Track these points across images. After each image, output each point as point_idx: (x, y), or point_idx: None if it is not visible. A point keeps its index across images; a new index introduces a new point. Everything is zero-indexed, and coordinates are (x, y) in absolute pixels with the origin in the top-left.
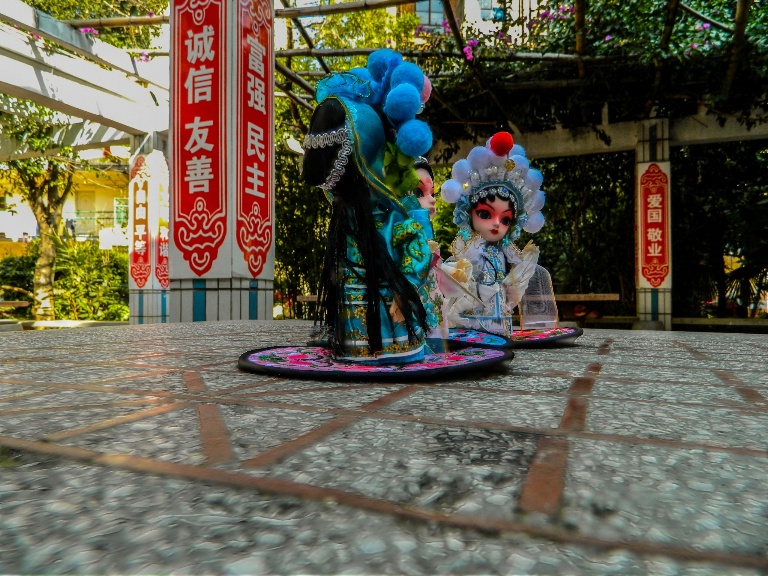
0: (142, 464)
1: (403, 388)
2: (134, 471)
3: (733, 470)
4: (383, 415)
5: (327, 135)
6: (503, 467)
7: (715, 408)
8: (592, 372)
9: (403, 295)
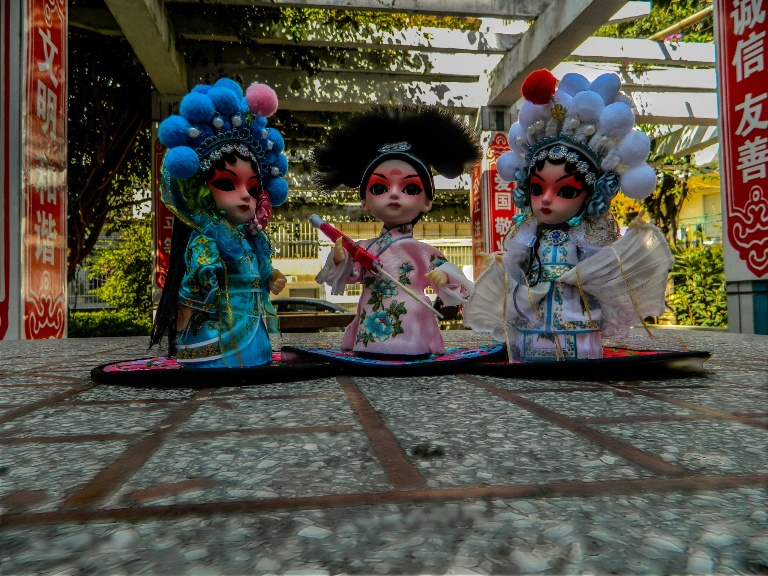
0: None
1: None
2: None
3: None
4: None
5: None
6: None
7: None
8: (232, 398)
9: (163, 307)
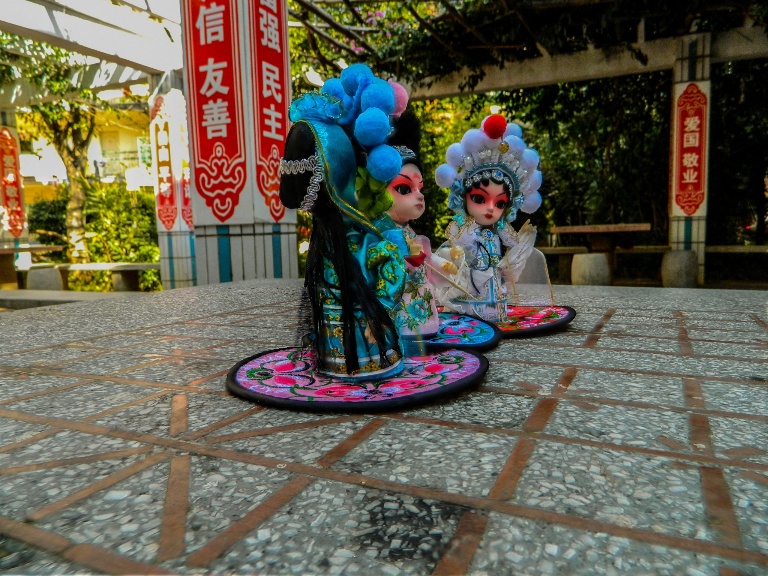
0: (100, 559)
1: (368, 423)
2: (92, 569)
3: (621, 568)
4: (334, 474)
5: (298, 162)
6: (414, 563)
7: (653, 455)
8: (561, 387)
9: (376, 320)
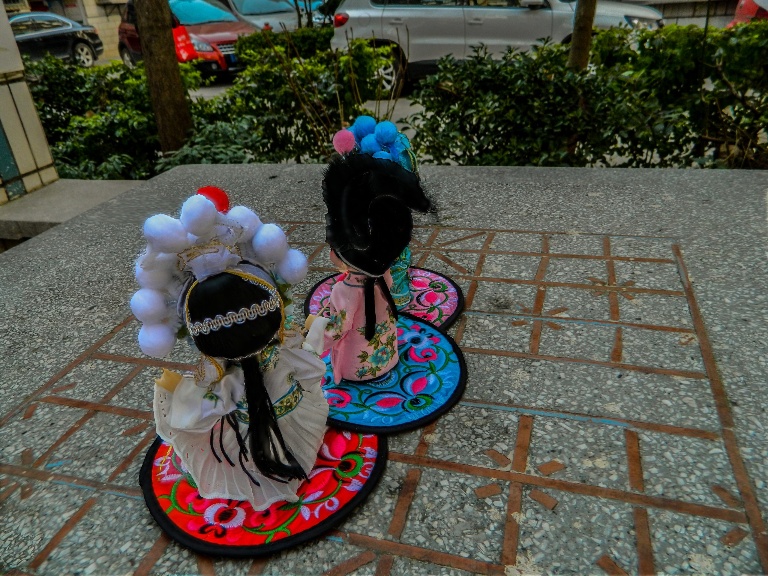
0: None
1: None
2: None
3: None
4: None
5: None
6: None
7: None
8: None
9: None
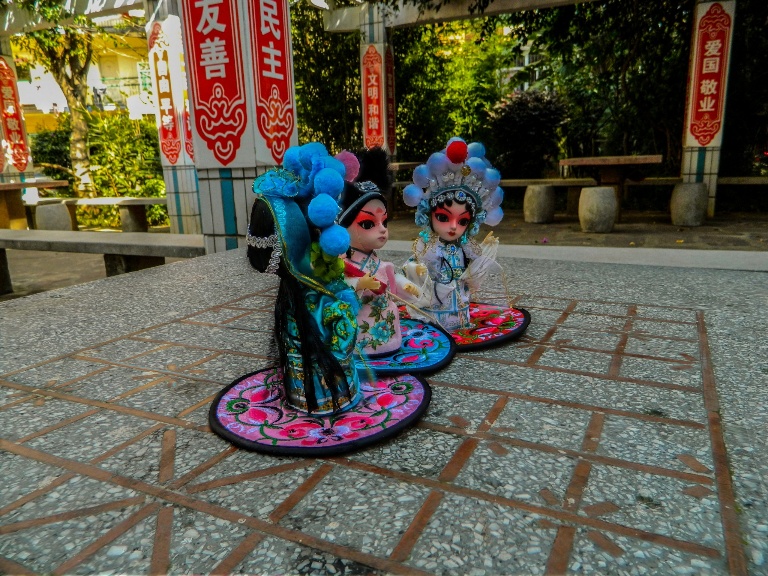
0: None
1: (317, 470)
2: None
3: None
4: (280, 531)
5: (261, 239)
6: None
7: (529, 512)
8: (487, 424)
9: (329, 373)
